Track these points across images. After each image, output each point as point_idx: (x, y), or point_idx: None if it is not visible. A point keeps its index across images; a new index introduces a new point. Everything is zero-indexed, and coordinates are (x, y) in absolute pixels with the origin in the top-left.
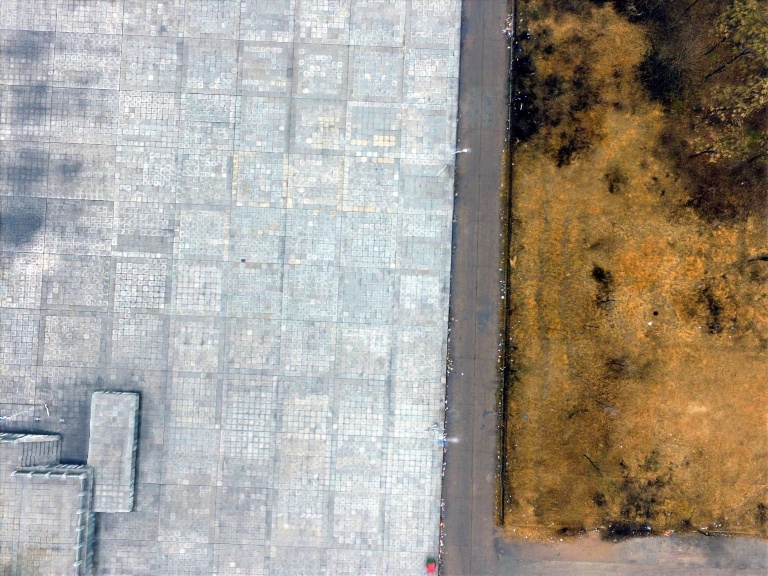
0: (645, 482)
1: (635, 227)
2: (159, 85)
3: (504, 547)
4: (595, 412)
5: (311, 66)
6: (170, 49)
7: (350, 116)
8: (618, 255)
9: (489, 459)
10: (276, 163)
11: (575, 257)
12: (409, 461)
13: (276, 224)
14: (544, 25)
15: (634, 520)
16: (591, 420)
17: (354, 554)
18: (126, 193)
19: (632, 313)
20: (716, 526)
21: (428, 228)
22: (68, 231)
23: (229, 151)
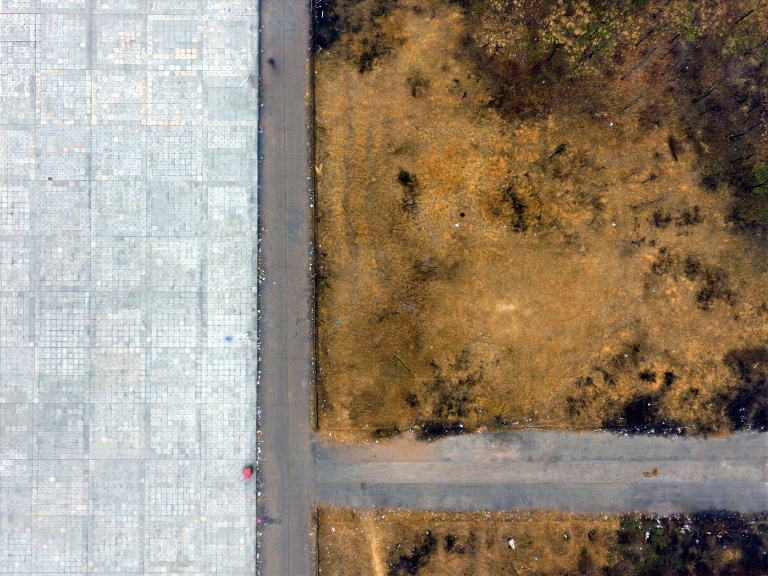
0: (456, 381)
1: (438, 129)
2: None
3: (321, 451)
4: (405, 314)
5: None
6: None
7: (151, 30)
8: (422, 158)
9: (303, 366)
10: (79, 80)
11: (380, 162)
12: (223, 371)
13: (81, 141)
14: None
15: (446, 418)
16: (401, 322)
17: (172, 464)
18: None
19: (438, 215)
20: (527, 421)
21: (233, 139)
22: None
23: (31, 70)
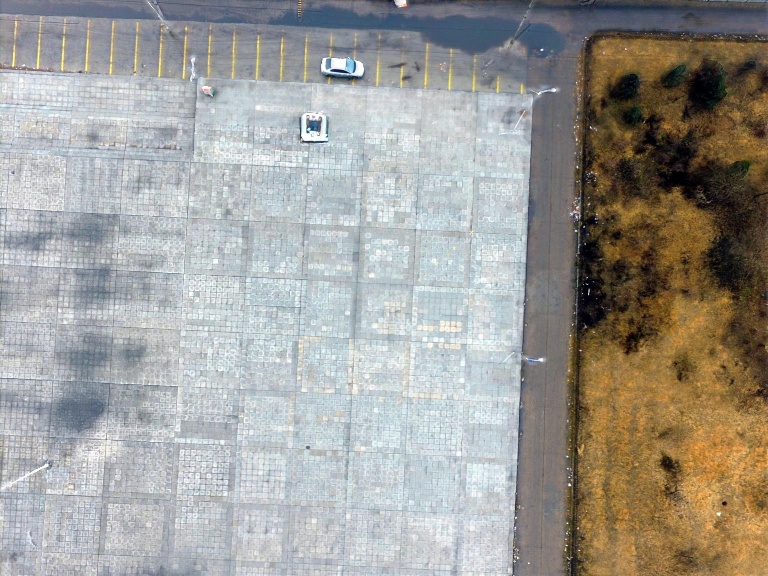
0: None
1: (704, 416)
2: (224, 269)
3: None
4: None
5: (377, 250)
6: (235, 232)
7: (416, 301)
8: (687, 445)
9: None
10: (342, 348)
11: (643, 446)
12: None
13: (341, 410)
14: (612, 210)
15: None
16: None
17: None
18: (190, 378)
19: (701, 504)
20: None
21: (495, 415)
22: (131, 417)
23: (294, 336)
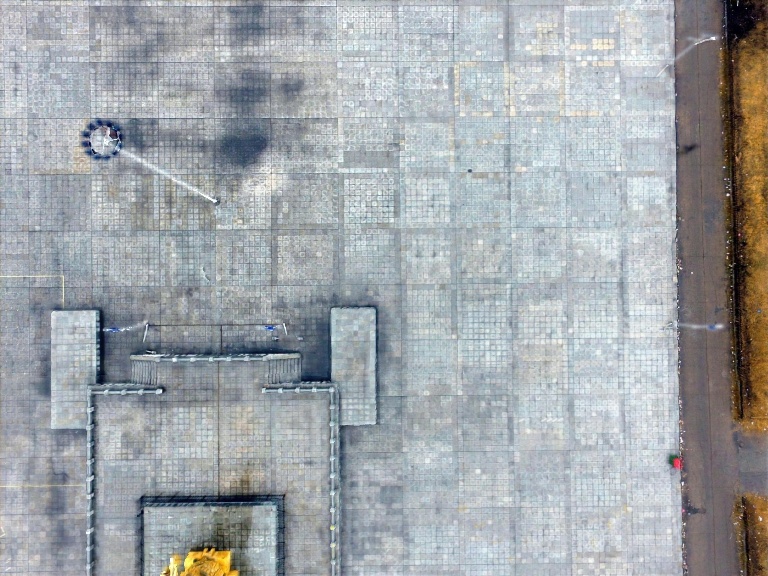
0: None
1: None
2: None
3: (743, 440)
4: None
5: None
6: None
7: (568, 21)
8: None
9: (723, 355)
10: (497, 72)
11: None
12: (646, 361)
13: (500, 133)
14: None
15: None
16: None
17: (597, 455)
18: (349, 109)
19: None
20: None
21: (652, 129)
22: (294, 150)
23: (449, 62)
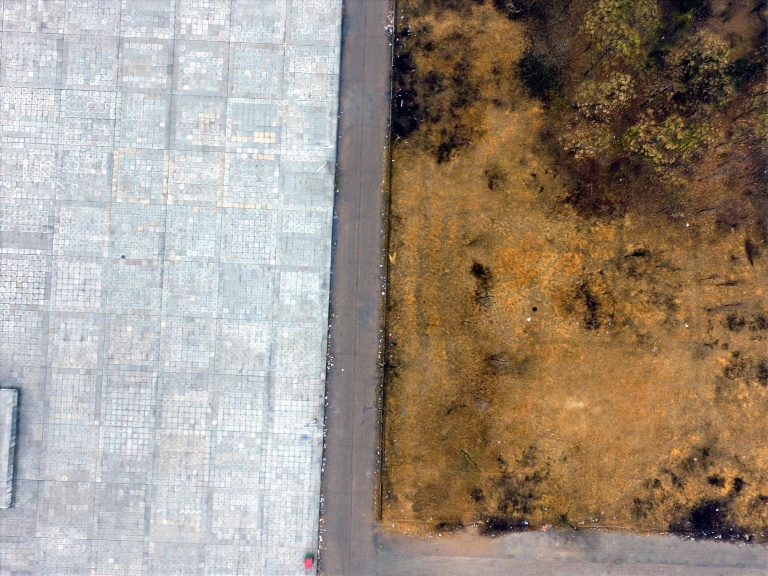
0: (522, 477)
1: (514, 223)
2: (39, 81)
3: (383, 542)
4: (473, 407)
5: (192, 63)
6: (50, 45)
7: (230, 113)
8: (497, 251)
9: (369, 455)
10: (156, 159)
11: (454, 253)
12: (288, 457)
13: (156, 220)
14: (424, 22)
15: (511, 515)
16: (469, 415)
17: (233, 550)
18: (6, 189)
19: (511, 309)
20: (593, 521)
21: (308, 224)
22: None
23: (109, 147)
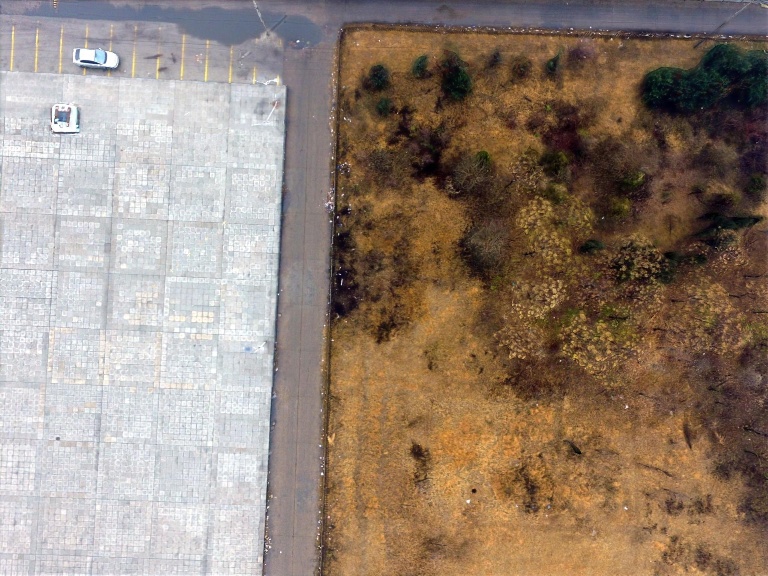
0: None
1: (453, 405)
2: None
3: None
4: None
5: (129, 241)
6: None
7: (168, 292)
8: (436, 433)
9: None
10: (93, 339)
11: (393, 435)
12: None
13: (92, 401)
14: (365, 201)
15: None
16: None
17: None
18: None
19: (450, 491)
20: None
21: (246, 405)
22: None
23: (45, 327)
